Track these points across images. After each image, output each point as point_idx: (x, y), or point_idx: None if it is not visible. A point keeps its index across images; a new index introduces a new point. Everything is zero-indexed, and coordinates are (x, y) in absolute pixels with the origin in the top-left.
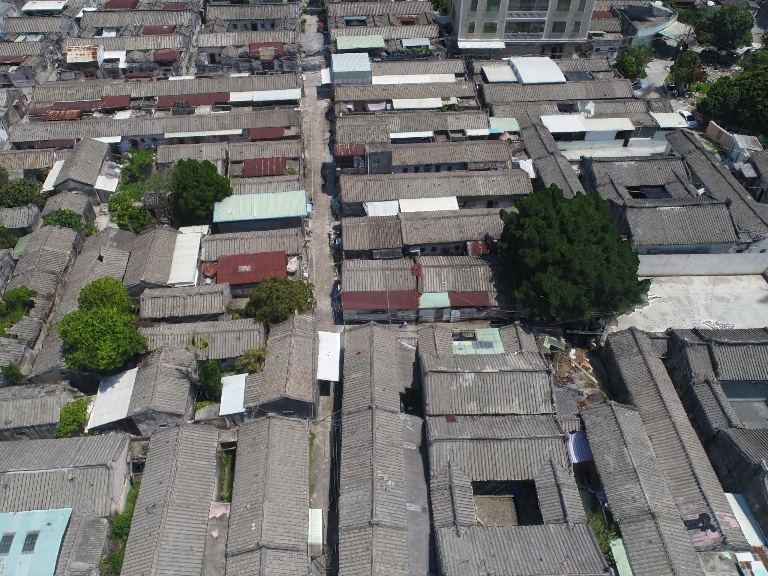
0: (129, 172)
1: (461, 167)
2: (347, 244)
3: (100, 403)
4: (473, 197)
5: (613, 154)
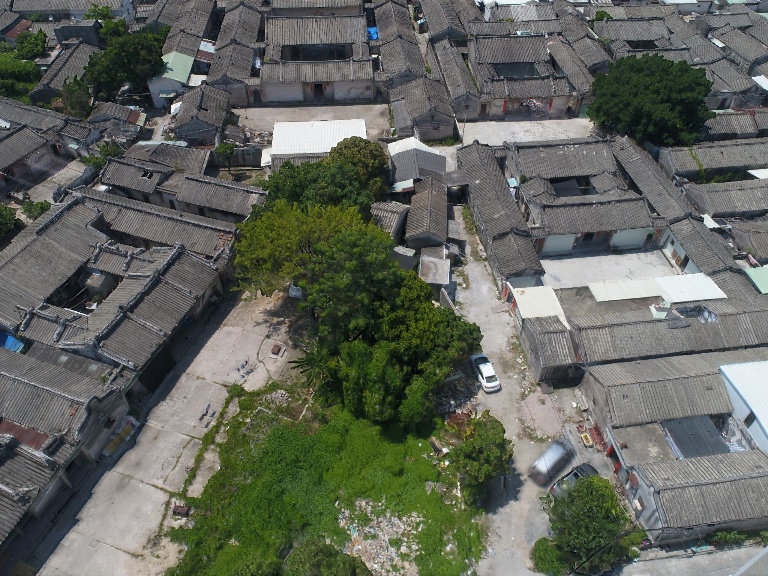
0: None
1: None
2: None
3: None
4: None
5: None
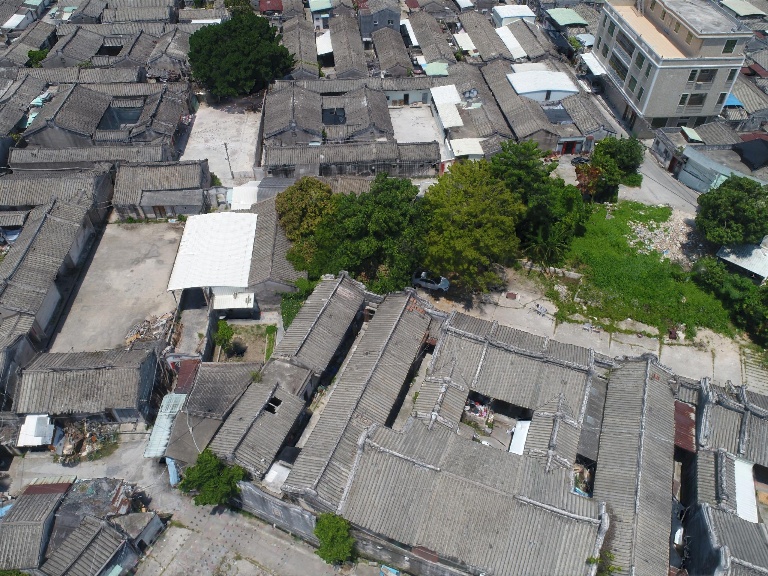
0: None
1: None
2: None
3: None
4: None
5: (431, 137)
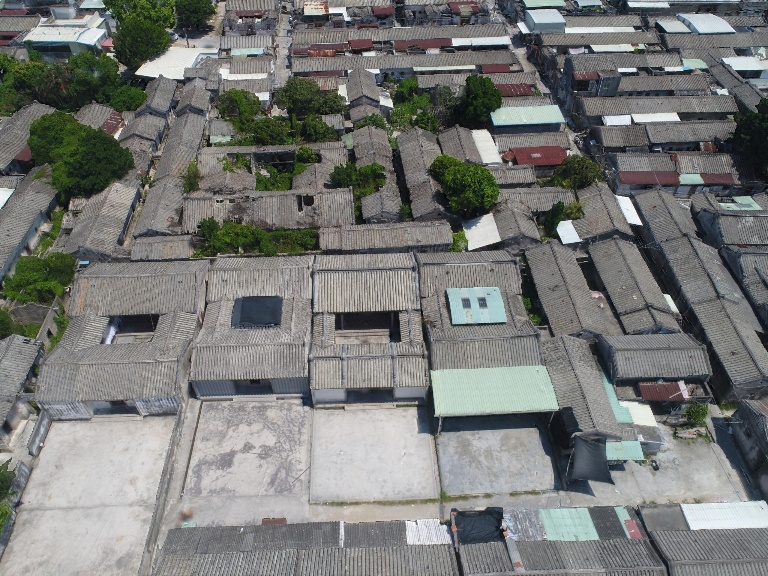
0: (400, 94)
1: (666, 95)
2: (606, 142)
3: (471, 235)
4: (688, 114)
5: None
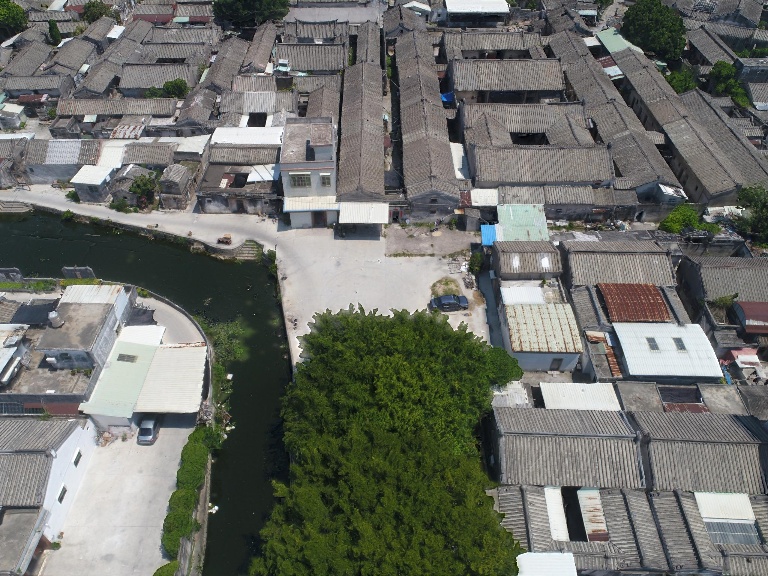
0: None
1: None
2: (147, 2)
3: (3, 44)
4: None
5: None
